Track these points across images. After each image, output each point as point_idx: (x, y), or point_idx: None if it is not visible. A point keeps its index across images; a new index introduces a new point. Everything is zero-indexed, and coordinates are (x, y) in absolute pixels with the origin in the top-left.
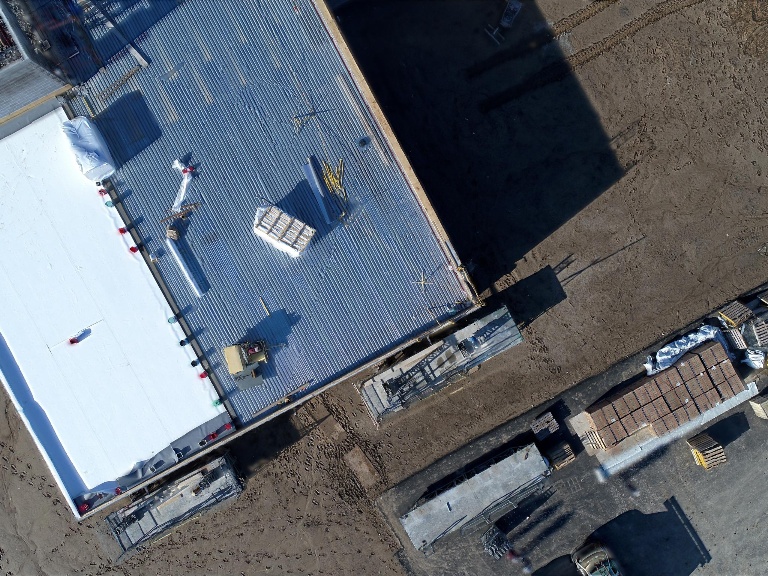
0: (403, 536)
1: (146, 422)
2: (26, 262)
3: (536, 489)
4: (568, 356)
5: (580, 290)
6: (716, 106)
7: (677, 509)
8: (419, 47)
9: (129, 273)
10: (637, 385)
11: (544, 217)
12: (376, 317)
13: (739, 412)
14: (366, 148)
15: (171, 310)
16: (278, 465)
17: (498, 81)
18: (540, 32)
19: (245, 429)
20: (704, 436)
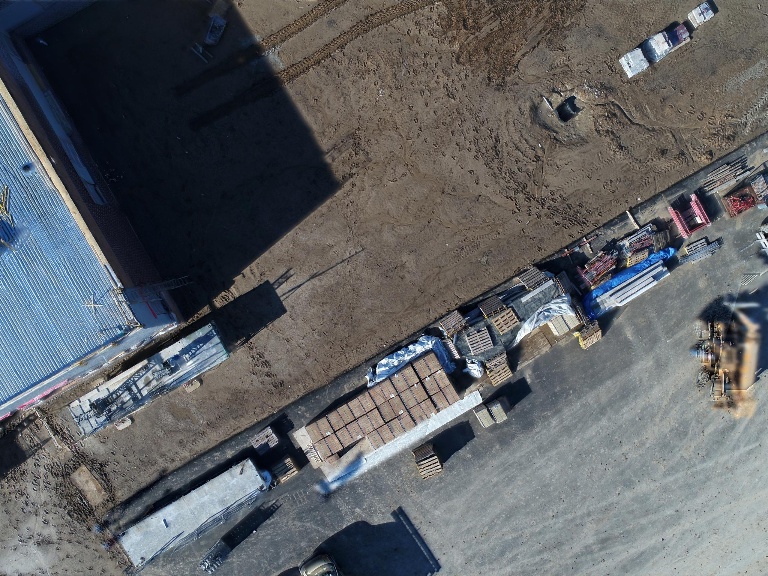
0: None
1: None
2: None
3: (247, 504)
4: (290, 370)
5: (300, 304)
6: (430, 116)
7: (404, 519)
8: (128, 68)
9: None
10: (354, 397)
11: (260, 233)
12: (47, 341)
13: (463, 421)
14: (32, 174)
15: None
16: (6, 486)
17: (209, 99)
18: (249, 49)
19: None
20: (427, 446)
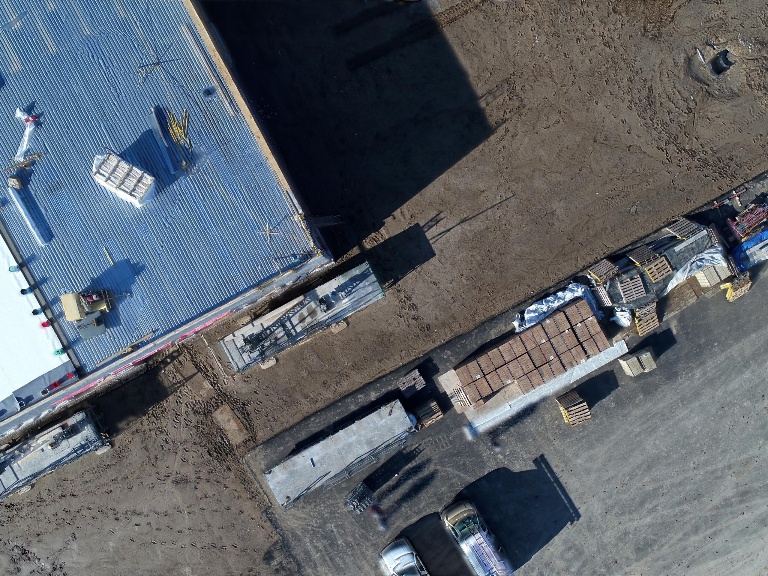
0: (271, 493)
1: None
2: None
3: (398, 444)
4: (437, 314)
5: (449, 248)
6: (585, 64)
7: (546, 467)
8: (286, 4)
9: None
10: (503, 342)
11: (412, 175)
12: (221, 267)
13: (608, 370)
14: (211, 98)
15: (14, 259)
16: (146, 422)
17: (366, 38)
18: None
19: (86, 378)
20: (572, 394)
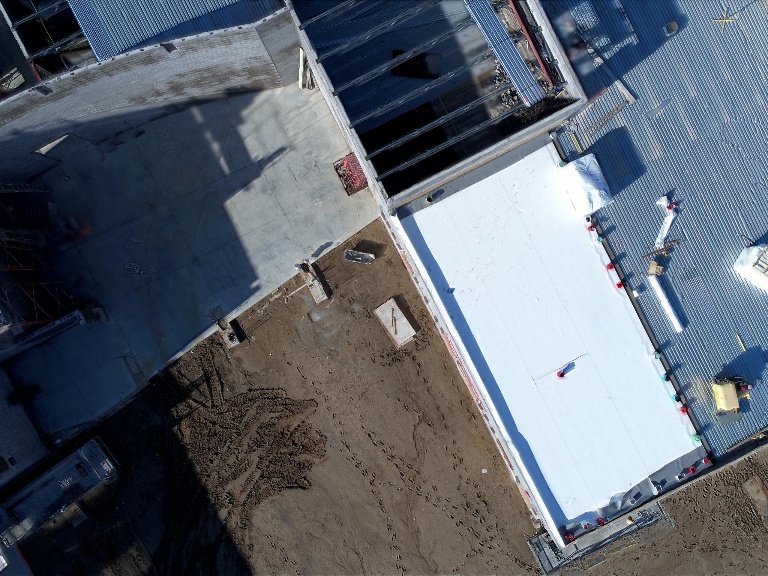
0: None
1: (625, 455)
2: (514, 296)
3: None
4: None
5: None
6: None
7: None
8: None
9: (613, 308)
10: None
11: None
12: None
13: None
14: None
15: (652, 345)
16: (677, 492)
17: None
18: None
19: (727, 464)
20: None
